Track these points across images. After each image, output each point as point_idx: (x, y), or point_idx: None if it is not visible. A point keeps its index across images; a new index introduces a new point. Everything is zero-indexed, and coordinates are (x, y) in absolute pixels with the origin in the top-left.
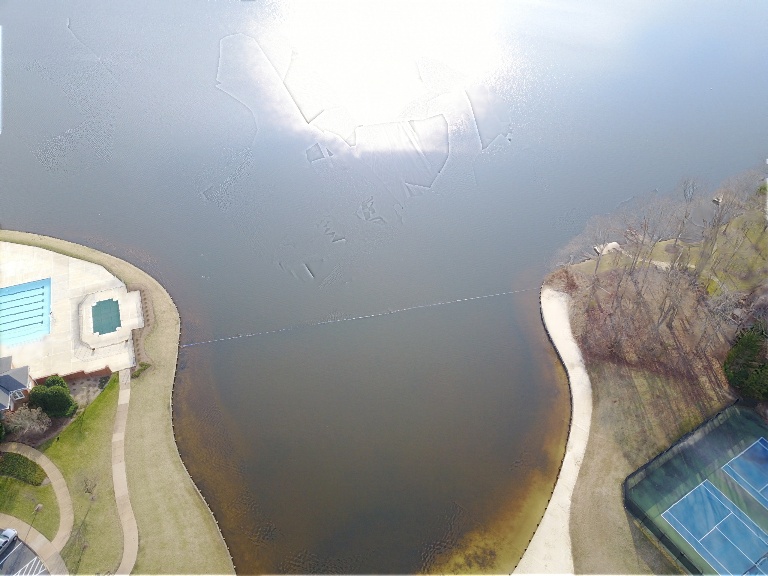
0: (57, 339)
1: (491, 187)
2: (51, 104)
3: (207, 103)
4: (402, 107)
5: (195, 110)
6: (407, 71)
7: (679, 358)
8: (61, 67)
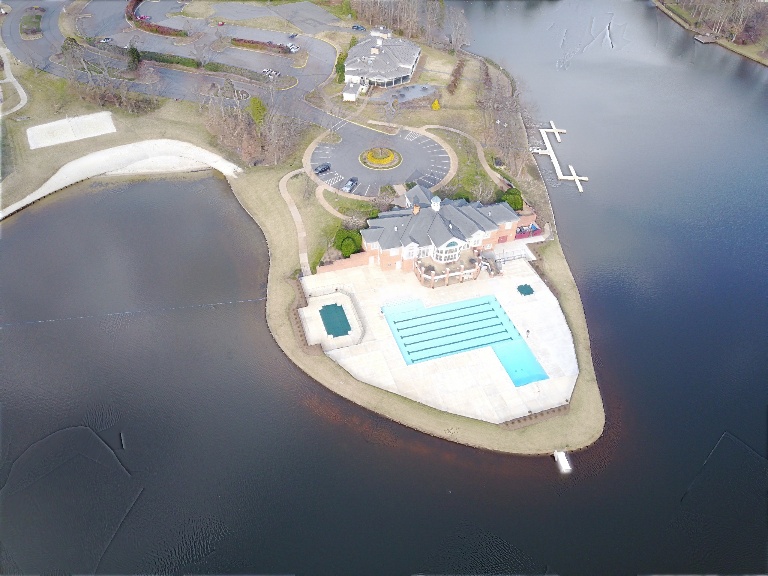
0: (372, 302)
1: None
2: None
3: None
4: None
5: None
6: None
7: None
8: None
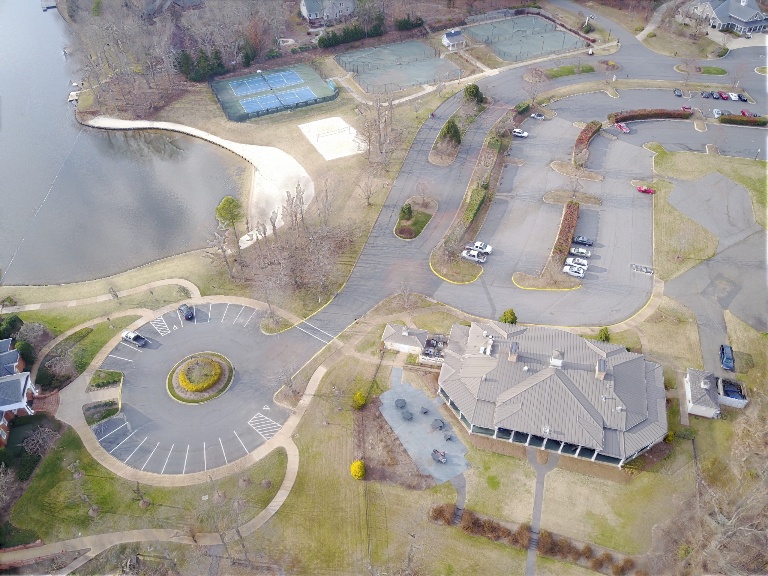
0: None
1: None
2: None
3: None
4: None
5: None
6: None
7: (173, 91)
8: None
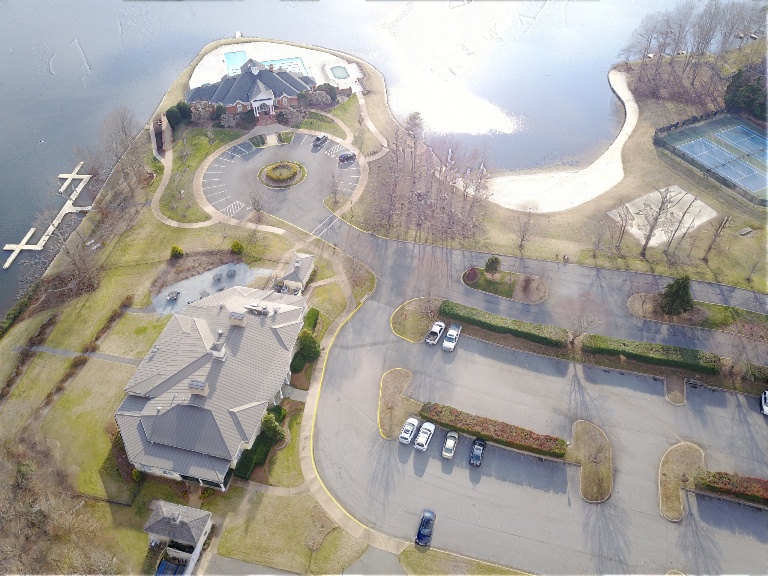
0: None
1: (576, 26)
2: None
3: None
4: None
5: None
6: None
7: (696, 96)
8: None
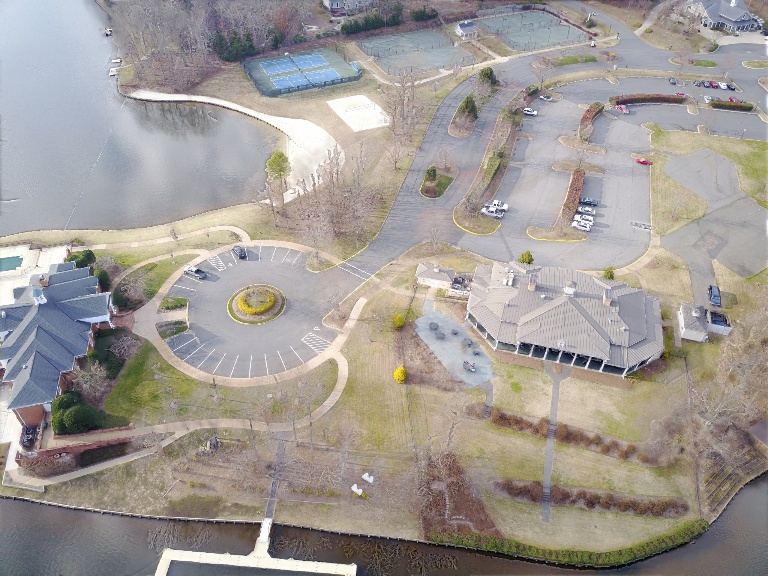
0: (6, 289)
1: (13, 95)
2: None
3: None
4: None
5: None
6: None
7: (208, 68)
8: None
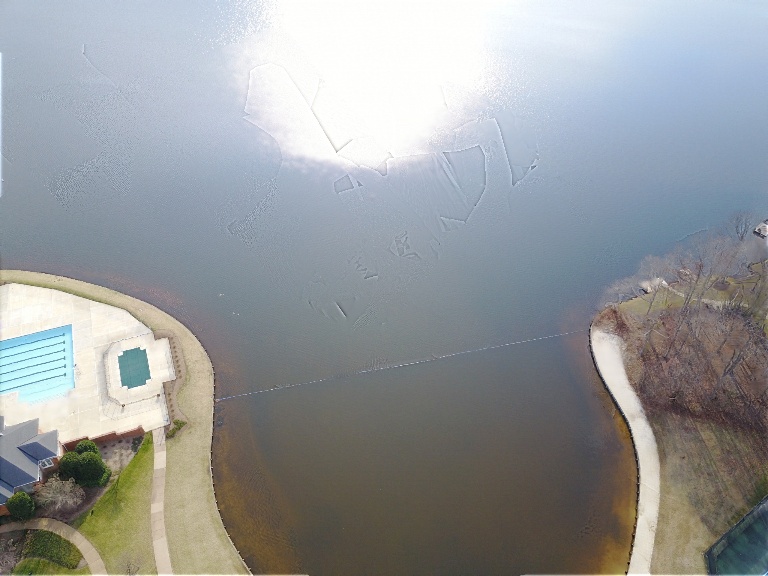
0: (83, 394)
1: (526, 219)
2: (66, 135)
3: (230, 133)
4: (428, 134)
5: (217, 140)
6: (433, 97)
7: (745, 408)
8: (77, 96)
